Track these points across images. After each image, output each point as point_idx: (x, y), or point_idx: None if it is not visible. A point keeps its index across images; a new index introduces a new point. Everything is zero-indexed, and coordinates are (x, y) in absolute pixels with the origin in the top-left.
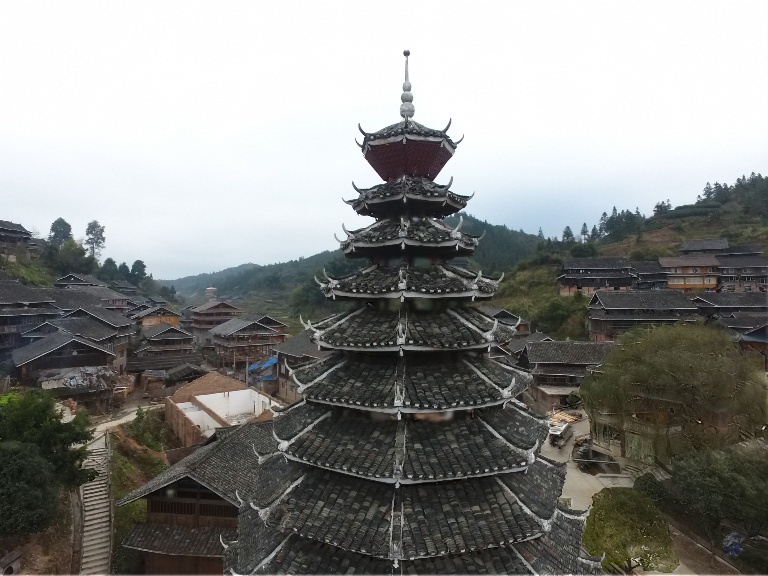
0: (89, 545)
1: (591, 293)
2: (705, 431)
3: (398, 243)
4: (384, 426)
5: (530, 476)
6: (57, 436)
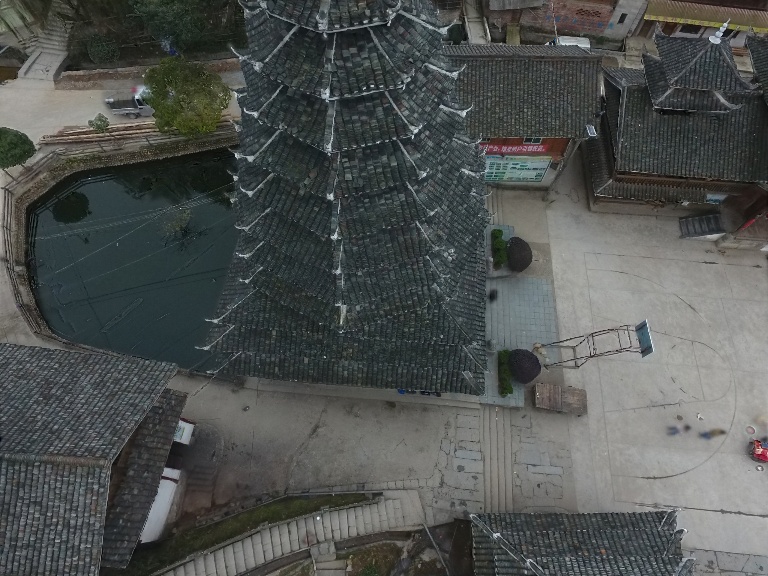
0: None
1: None
2: None
3: None
4: None
5: None
6: None
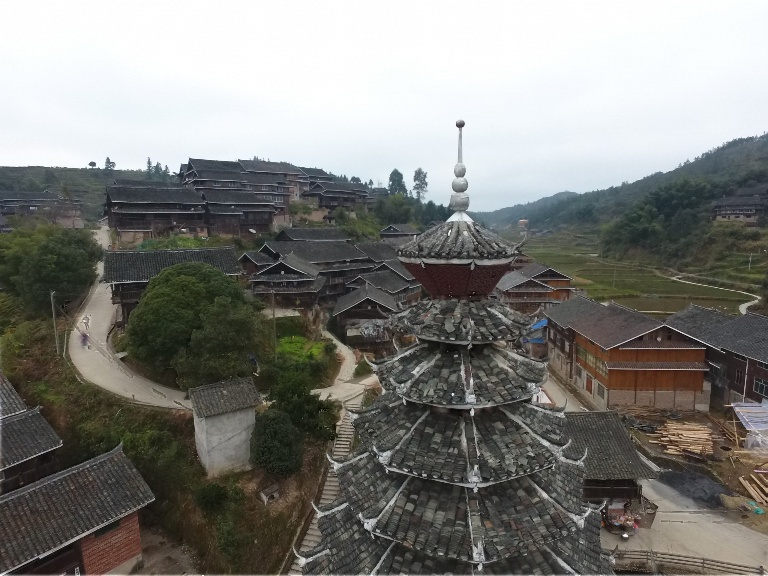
0: (327, 489)
1: None
2: None
3: (400, 396)
4: None
5: None
6: (304, 407)
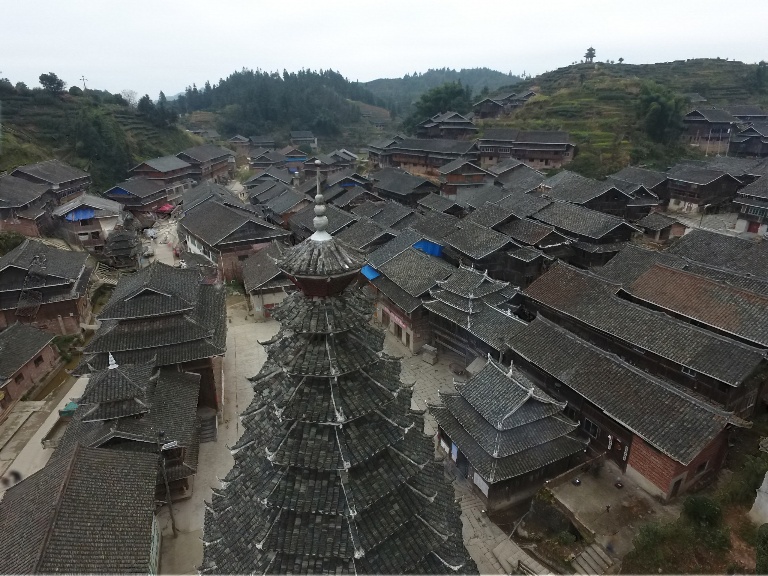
0: None
1: None
2: None
3: None
4: None
5: None
6: None
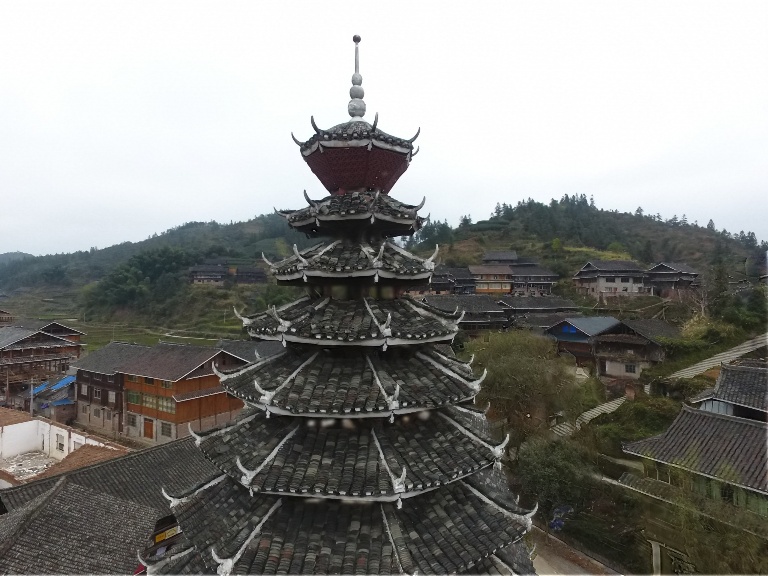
0: None
1: (417, 296)
2: (540, 426)
3: (370, 275)
4: (362, 512)
5: None
6: None
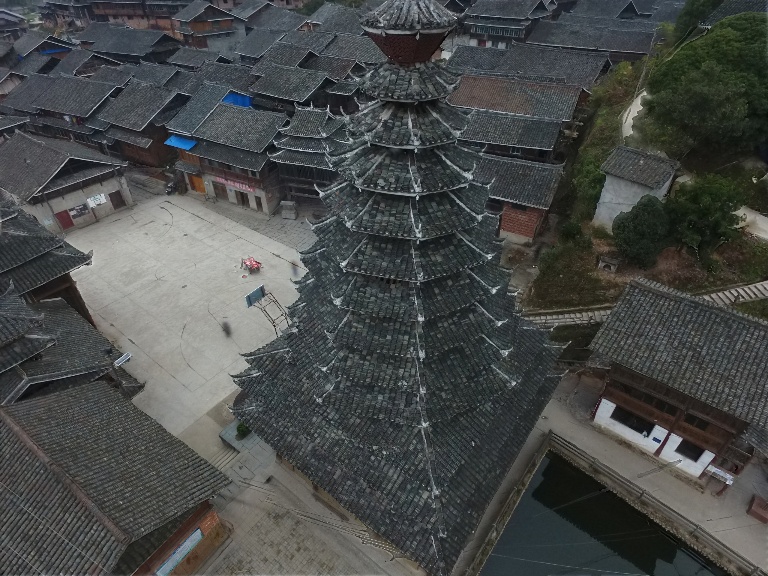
0: None
1: None
2: None
3: None
4: None
5: (329, 301)
6: None
